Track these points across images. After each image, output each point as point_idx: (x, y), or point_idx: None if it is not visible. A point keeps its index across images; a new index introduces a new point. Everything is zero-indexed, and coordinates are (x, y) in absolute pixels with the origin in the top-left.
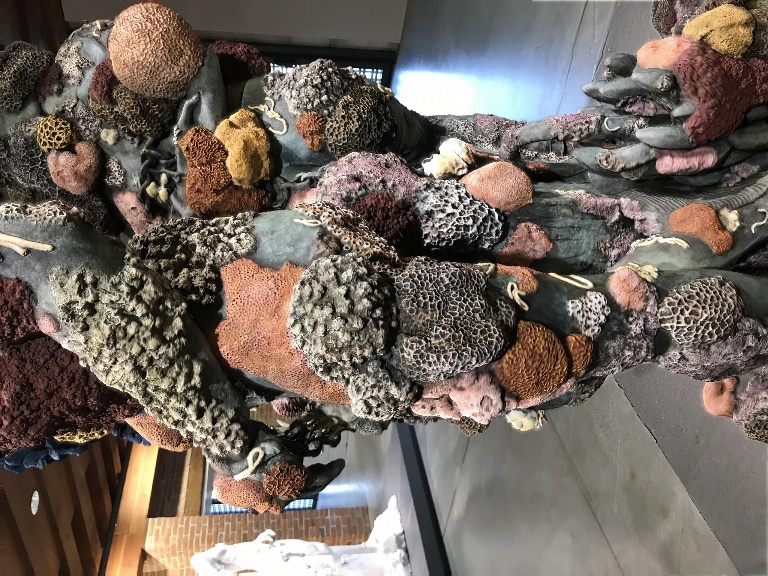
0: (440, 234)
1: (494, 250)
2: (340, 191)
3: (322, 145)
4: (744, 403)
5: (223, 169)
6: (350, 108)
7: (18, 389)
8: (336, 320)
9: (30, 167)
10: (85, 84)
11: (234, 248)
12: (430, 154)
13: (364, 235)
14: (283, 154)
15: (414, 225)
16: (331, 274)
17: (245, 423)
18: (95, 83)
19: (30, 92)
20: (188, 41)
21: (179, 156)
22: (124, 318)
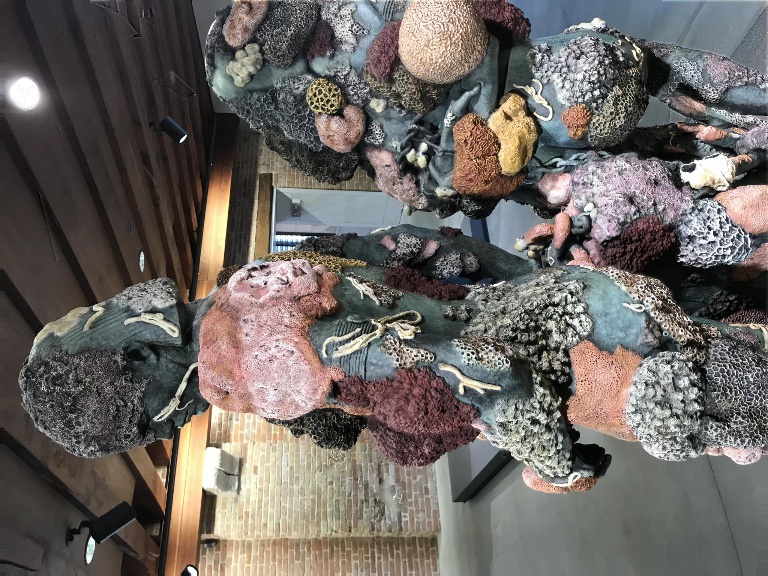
0: (698, 259)
1: (733, 263)
2: (617, 215)
3: (583, 135)
4: None
5: (495, 162)
6: (618, 102)
7: (437, 446)
8: (673, 420)
9: (299, 124)
10: (359, 52)
11: (578, 330)
12: None
13: (676, 317)
14: (542, 137)
15: (674, 246)
16: (670, 380)
17: (572, 458)
18: (377, 62)
19: (299, 50)
20: (480, 35)
21: (446, 135)
22: (534, 424)
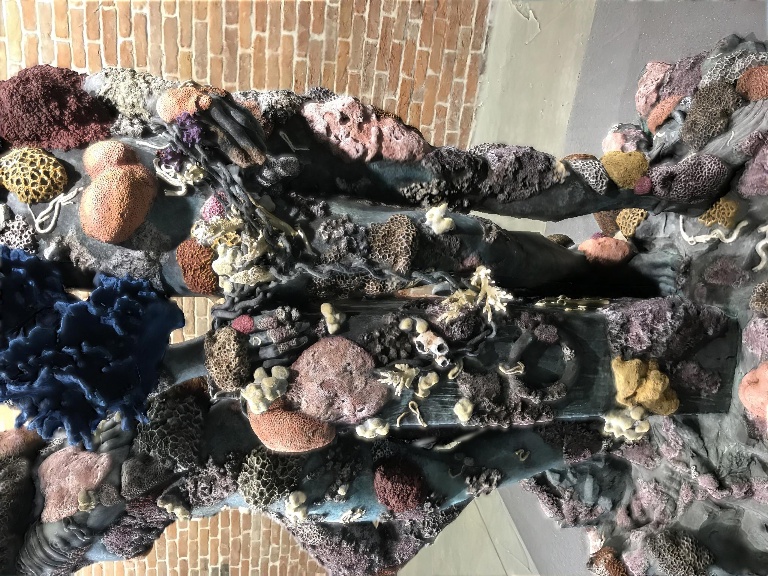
0: None
1: None
2: None
3: None
4: (763, 349)
5: None
6: None
7: None
8: None
9: None
10: None
11: None
12: (384, 537)
13: None
14: None
15: None
16: None
17: None
18: None
19: None
20: None
21: None
22: None
